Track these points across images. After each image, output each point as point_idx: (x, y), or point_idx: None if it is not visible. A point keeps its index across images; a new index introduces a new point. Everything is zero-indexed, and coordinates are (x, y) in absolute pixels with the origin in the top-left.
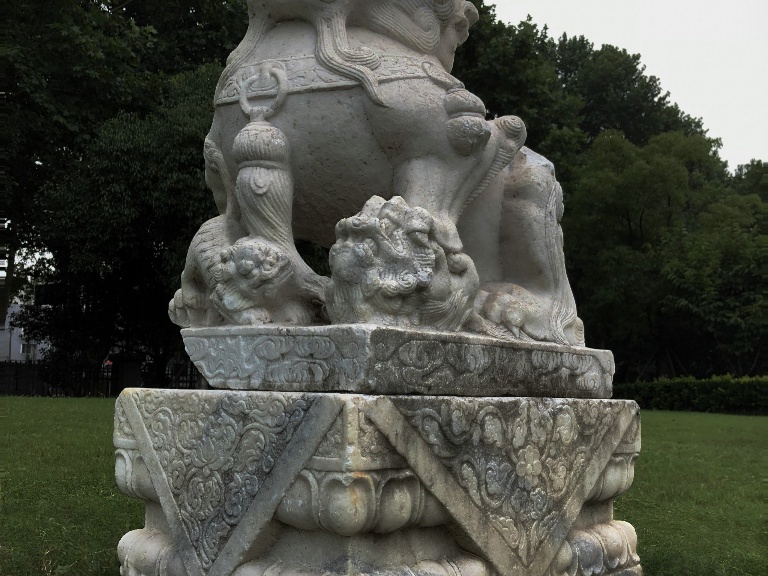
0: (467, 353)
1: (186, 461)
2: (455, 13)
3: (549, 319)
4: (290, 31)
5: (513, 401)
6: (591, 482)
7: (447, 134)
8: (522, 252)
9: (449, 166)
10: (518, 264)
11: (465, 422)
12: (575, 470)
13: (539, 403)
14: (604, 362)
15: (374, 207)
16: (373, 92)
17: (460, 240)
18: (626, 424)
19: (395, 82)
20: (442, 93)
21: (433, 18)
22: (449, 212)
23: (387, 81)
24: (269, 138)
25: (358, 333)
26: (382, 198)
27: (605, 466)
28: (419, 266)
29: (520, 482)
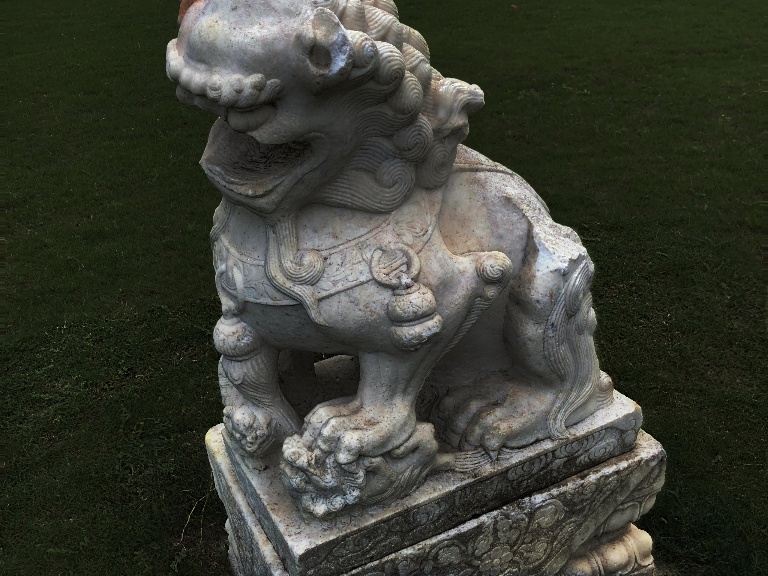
0: (416, 515)
1: (236, 525)
2: (442, 127)
3: (546, 418)
4: (250, 215)
5: (474, 527)
6: (583, 538)
7: (391, 340)
8: (521, 360)
9: (399, 360)
10: (521, 363)
11: (414, 565)
12: (560, 539)
13: (514, 509)
14: (625, 425)
15: (315, 426)
16: (311, 316)
17: (411, 424)
18: (641, 477)
19: (335, 296)
20: (387, 295)
21: (400, 168)
22: (404, 394)
23: (327, 297)
24: (235, 343)
25: (291, 552)
26: (325, 413)
27: (607, 517)
28: (348, 488)
29: (484, 575)
